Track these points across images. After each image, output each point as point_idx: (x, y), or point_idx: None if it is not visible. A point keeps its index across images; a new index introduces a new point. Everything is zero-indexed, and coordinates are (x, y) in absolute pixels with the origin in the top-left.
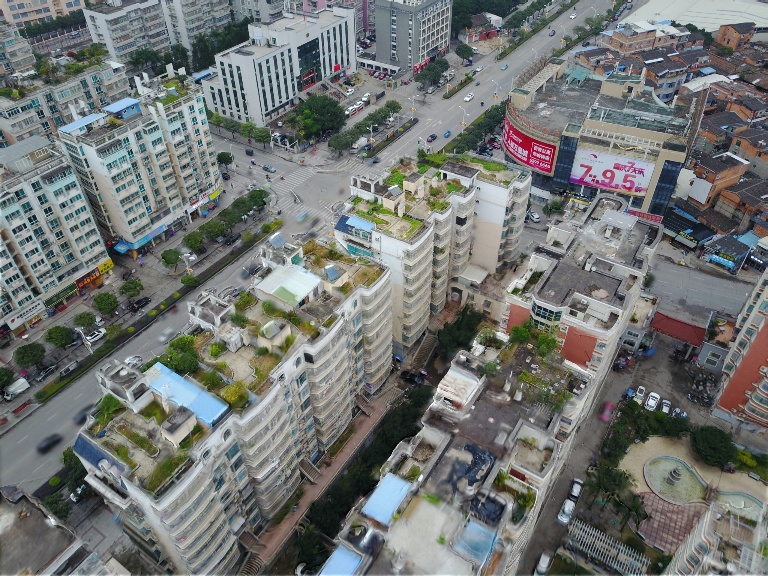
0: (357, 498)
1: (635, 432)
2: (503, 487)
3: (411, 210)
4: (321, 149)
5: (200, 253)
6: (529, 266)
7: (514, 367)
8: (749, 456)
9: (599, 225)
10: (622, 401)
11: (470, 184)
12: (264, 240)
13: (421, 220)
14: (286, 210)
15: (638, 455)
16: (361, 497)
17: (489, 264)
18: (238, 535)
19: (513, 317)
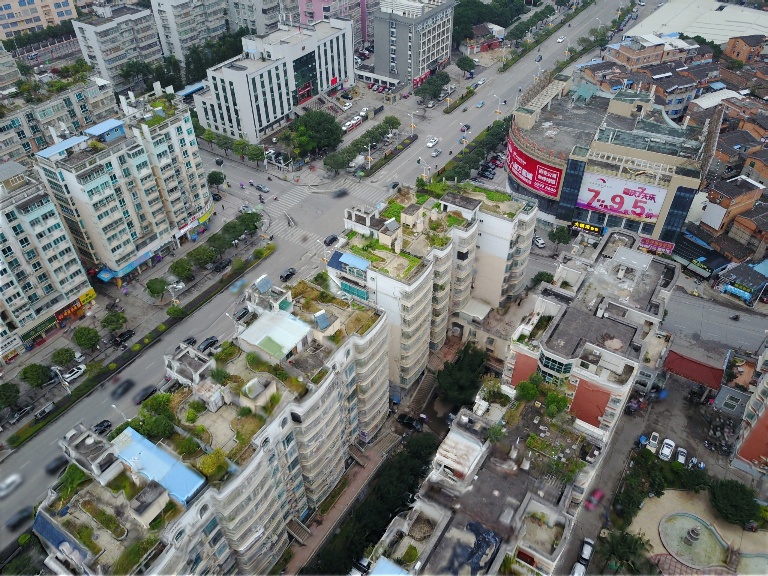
0: (350, 562)
1: (649, 485)
2: (510, 575)
3: (409, 246)
4: (317, 167)
5: (188, 281)
6: (536, 309)
7: (521, 429)
8: None
9: (611, 264)
10: (634, 449)
11: (472, 217)
12: (255, 266)
13: (420, 257)
14: (279, 234)
15: (653, 511)
16: (354, 560)
17: (492, 298)
18: None
19: (519, 366)
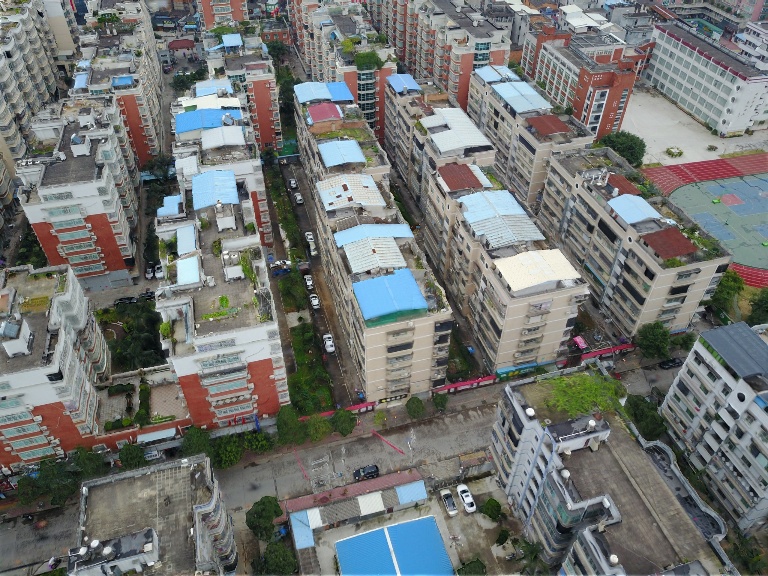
0: None
1: None
2: None
3: (9, 7)
4: None
5: None
6: (90, 9)
7: None
8: None
9: None
10: None
11: None
12: None
13: (19, 8)
14: None
15: None
16: None
17: (70, 47)
18: (26, 146)
19: None
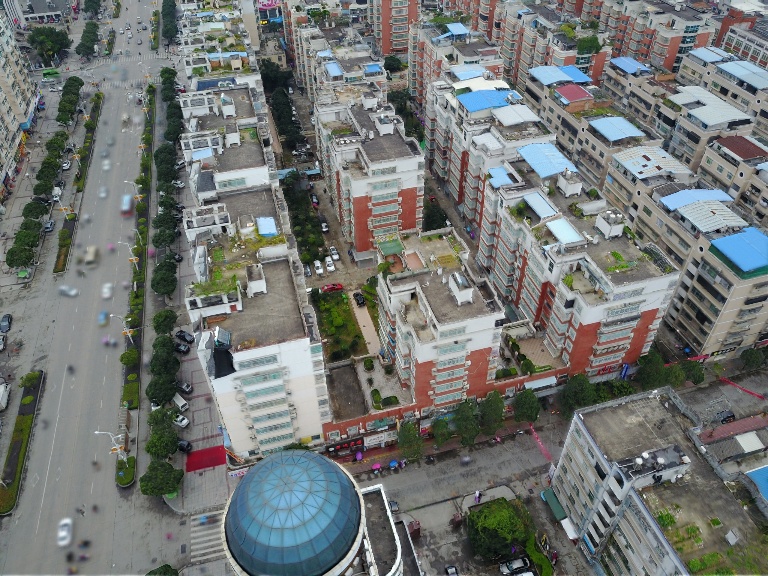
0: None
1: None
2: None
3: None
4: (70, 62)
5: (72, 119)
6: (291, 5)
7: None
8: (405, 64)
9: None
10: None
11: None
12: (103, 102)
13: (231, 5)
14: None
15: None
16: None
17: (256, 43)
18: None
19: None
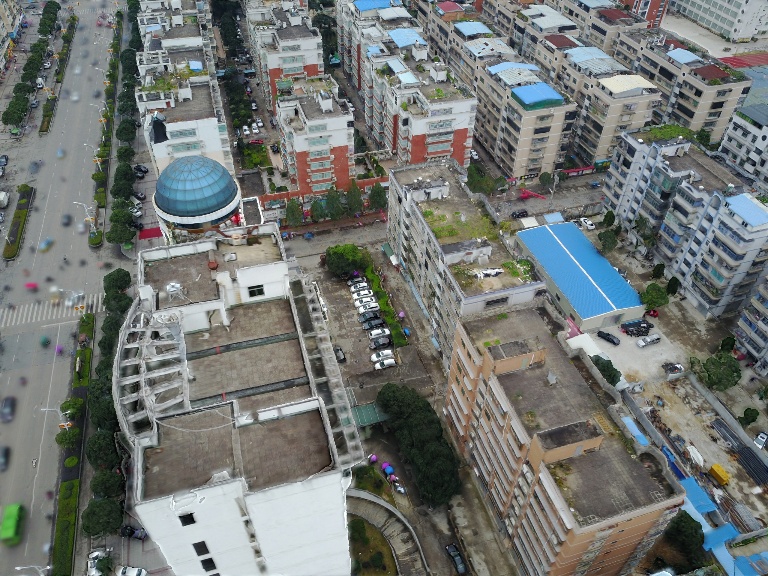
0: None
1: None
2: None
3: None
4: None
5: (51, 34)
6: None
7: None
8: None
9: None
10: None
11: None
12: (78, 24)
13: None
14: None
15: None
16: None
17: None
18: None
19: None
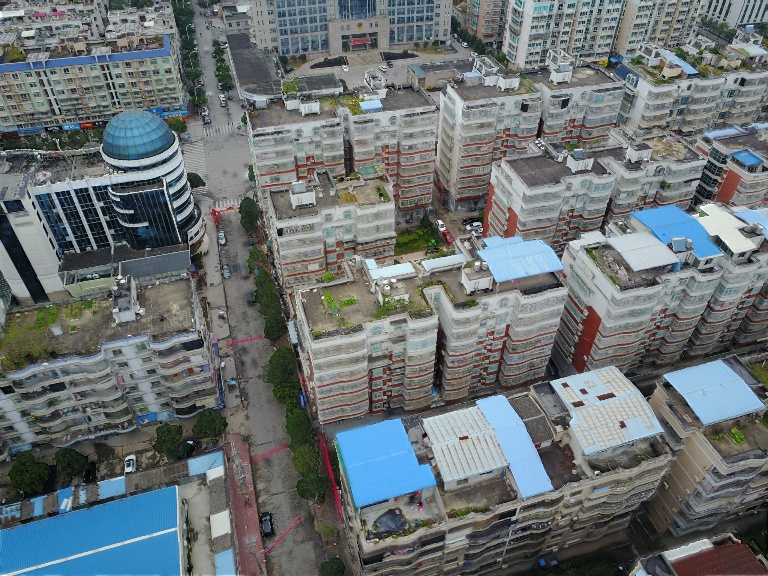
0: None
1: None
2: None
3: None
4: None
5: None
6: None
7: None
8: None
9: None
10: None
11: None
12: None
13: None
14: None
15: None
16: None
17: None
18: None
19: None
